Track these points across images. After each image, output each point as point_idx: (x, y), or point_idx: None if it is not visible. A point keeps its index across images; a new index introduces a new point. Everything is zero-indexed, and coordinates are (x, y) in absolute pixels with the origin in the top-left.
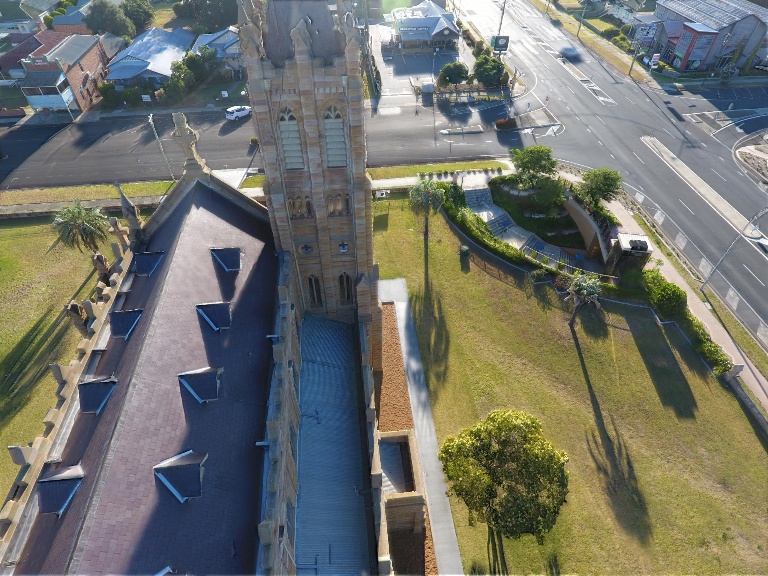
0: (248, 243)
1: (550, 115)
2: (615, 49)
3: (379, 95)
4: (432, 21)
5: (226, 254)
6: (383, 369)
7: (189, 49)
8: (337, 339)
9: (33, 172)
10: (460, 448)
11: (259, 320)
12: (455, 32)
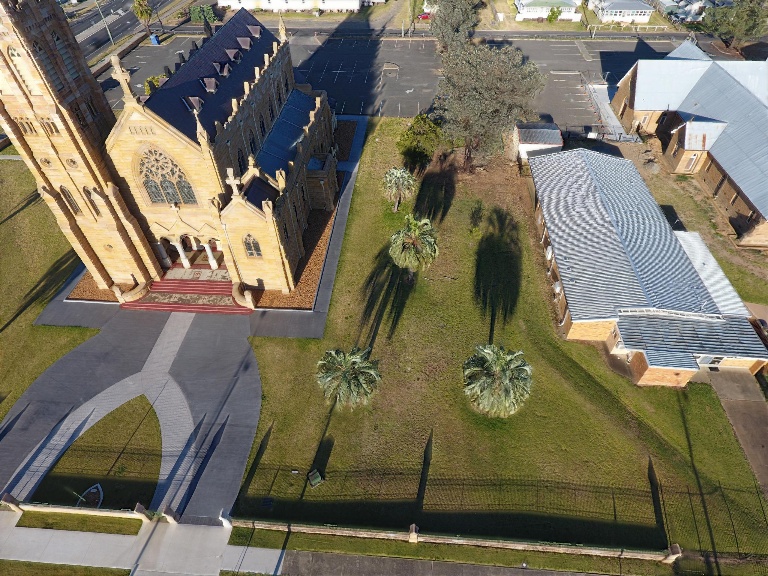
0: None
1: None
2: None
3: None
4: None
5: None
6: None
7: None
8: None
9: None
10: None
11: None
12: None
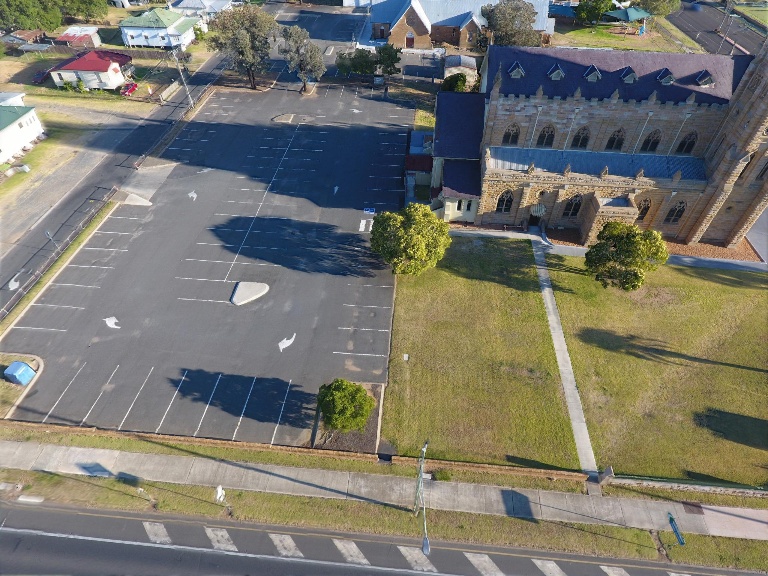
0: (725, 89)
1: None
2: None
3: None
4: None
5: (706, 74)
6: (689, 245)
7: None
8: (691, 178)
9: None
10: (632, 227)
11: (673, 100)
12: None
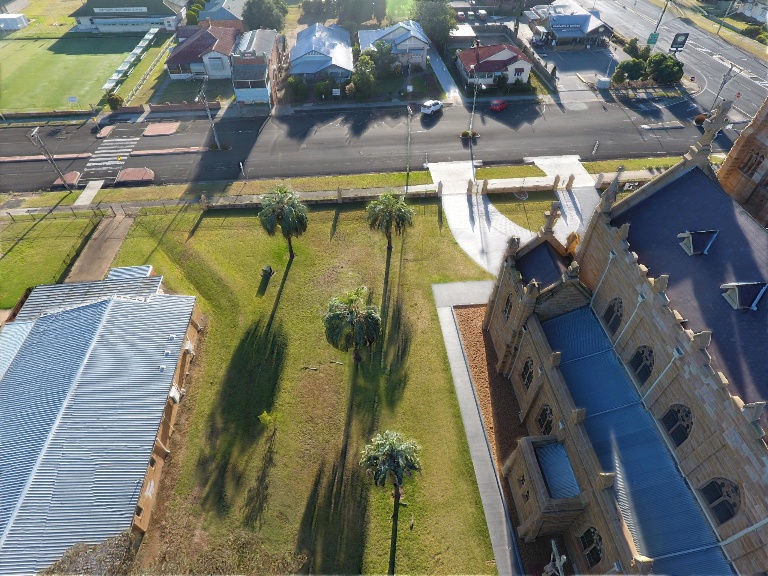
0: None
1: (741, 111)
2: (764, 47)
3: (556, 91)
4: (583, 18)
5: None
6: None
7: (355, 45)
8: None
9: (265, 163)
10: None
11: None
12: (609, 29)
